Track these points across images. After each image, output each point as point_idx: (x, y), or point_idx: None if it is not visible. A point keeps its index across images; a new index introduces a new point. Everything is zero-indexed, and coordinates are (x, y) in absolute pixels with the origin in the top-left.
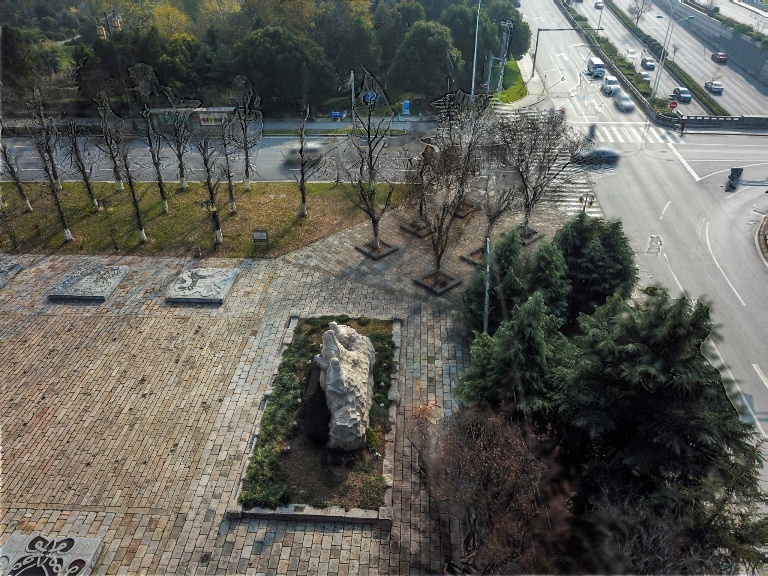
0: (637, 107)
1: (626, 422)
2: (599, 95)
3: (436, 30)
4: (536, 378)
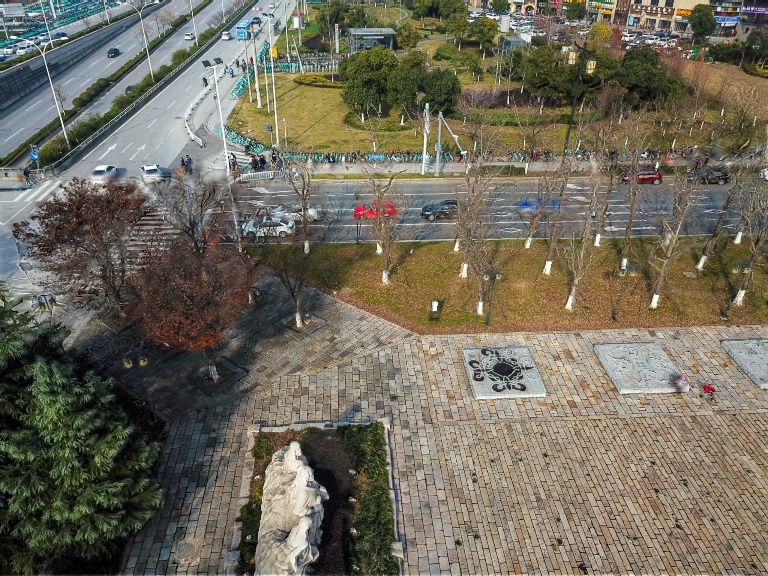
0: None
1: None
2: None
3: None
4: None
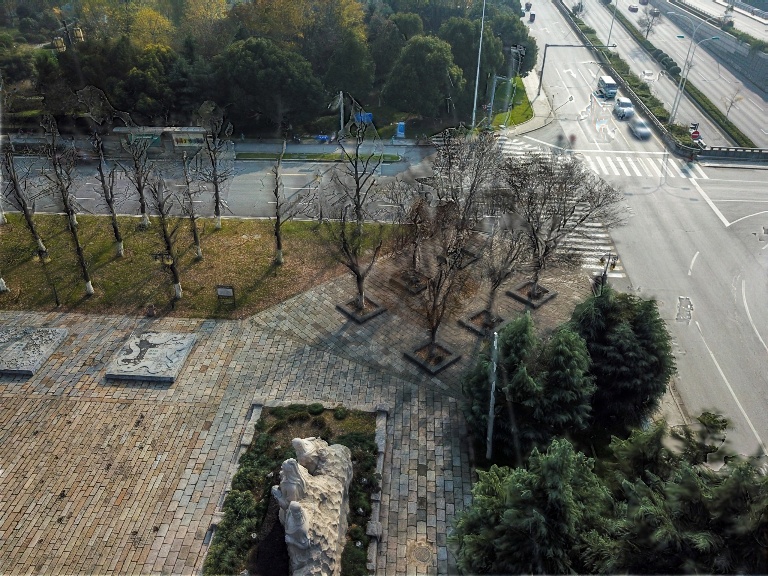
0: (653, 134)
1: None
2: (611, 118)
3: (435, 46)
4: (562, 556)
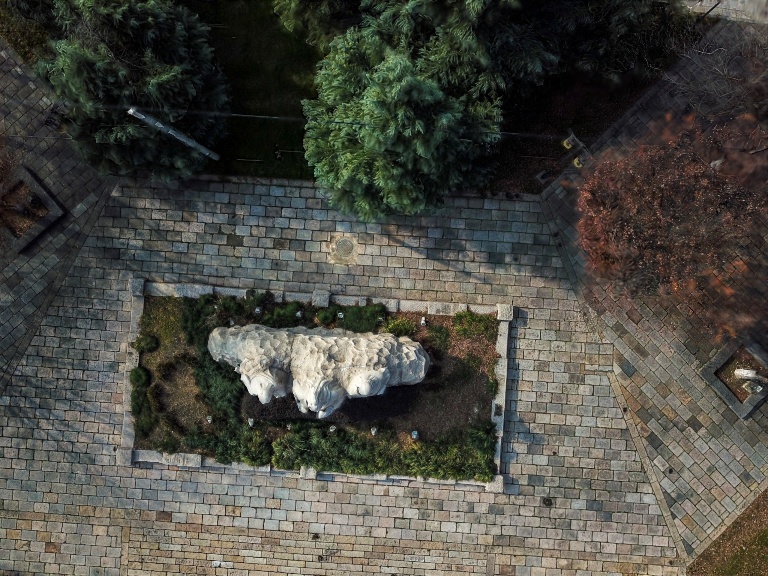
0: None
1: (515, 7)
2: None
3: None
4: None
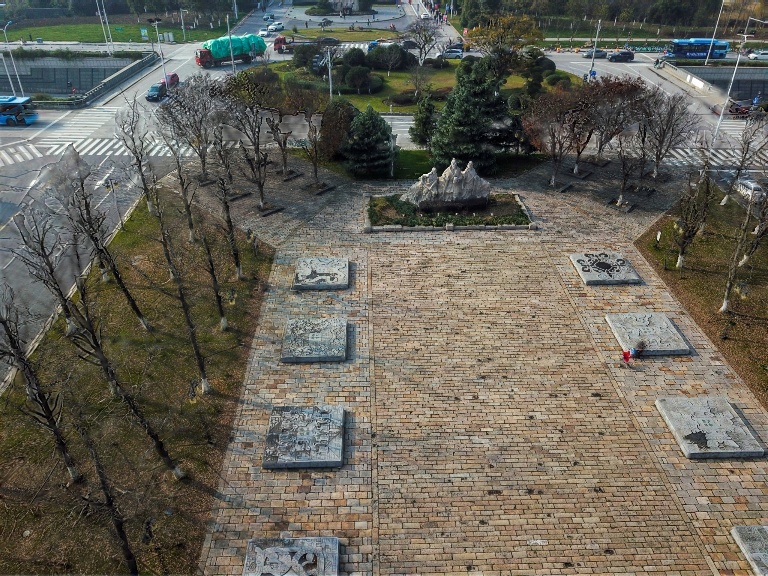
0: None
1: None
2: None
3: None
4: None
